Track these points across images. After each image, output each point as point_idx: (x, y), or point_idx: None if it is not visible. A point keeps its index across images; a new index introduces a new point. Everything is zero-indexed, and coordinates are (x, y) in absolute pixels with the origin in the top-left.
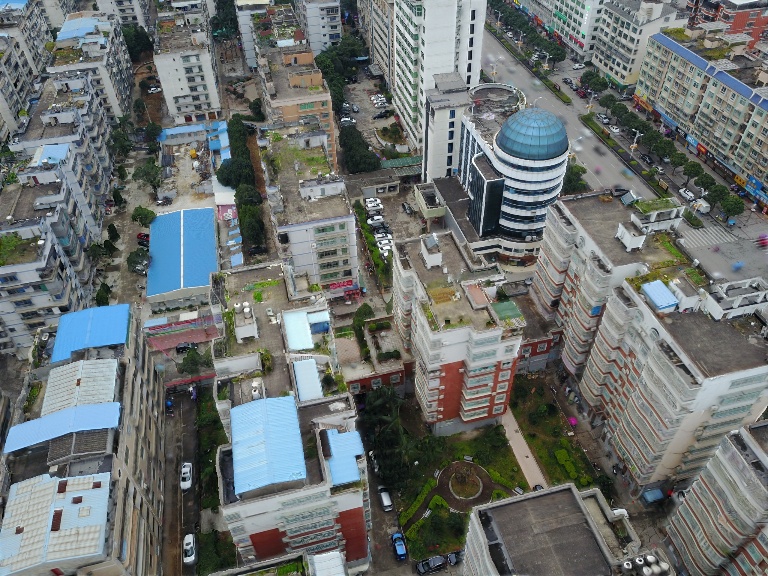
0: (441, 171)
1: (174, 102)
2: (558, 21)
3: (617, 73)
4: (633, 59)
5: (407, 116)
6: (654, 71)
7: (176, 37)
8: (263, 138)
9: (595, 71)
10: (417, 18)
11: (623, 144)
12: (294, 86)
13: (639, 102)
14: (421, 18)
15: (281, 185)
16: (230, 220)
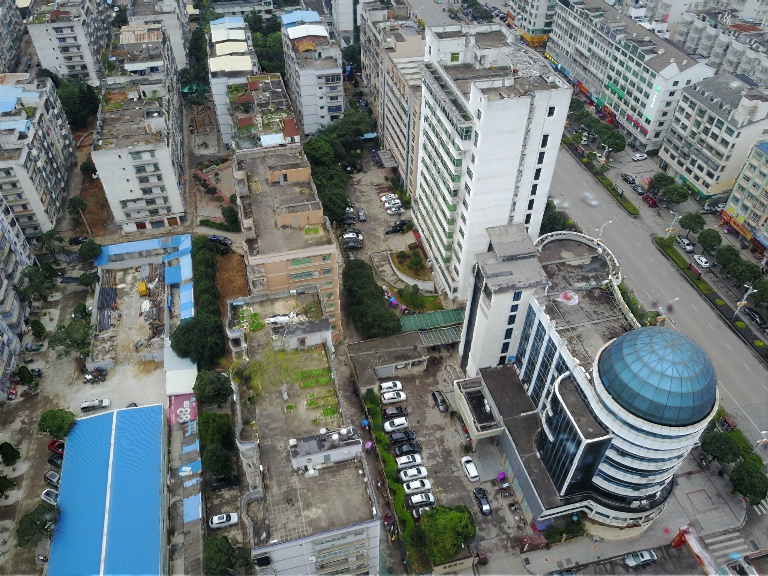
0: (492, 359)
1: (121, 207)
2: (611, 95)
3: (697, 178)
4: (723, 166)
5: (436, 249)
6: (758, 190)
7: (126, 118)
8: (236, 321)
9: (661, 165)
10: (464, 142)
11: (718, 288)
12: (283, 226)
13: (731, 223)
14: (470, 142)
15: (260, 433)
16: (186, 423)
